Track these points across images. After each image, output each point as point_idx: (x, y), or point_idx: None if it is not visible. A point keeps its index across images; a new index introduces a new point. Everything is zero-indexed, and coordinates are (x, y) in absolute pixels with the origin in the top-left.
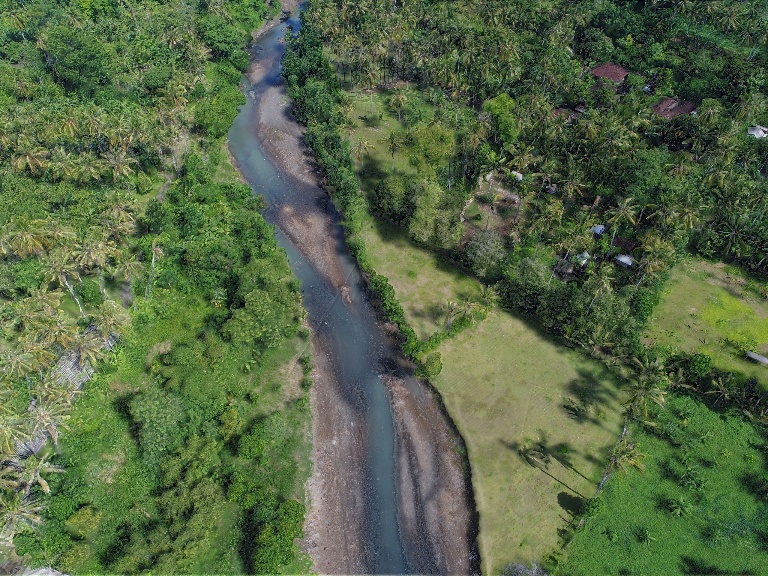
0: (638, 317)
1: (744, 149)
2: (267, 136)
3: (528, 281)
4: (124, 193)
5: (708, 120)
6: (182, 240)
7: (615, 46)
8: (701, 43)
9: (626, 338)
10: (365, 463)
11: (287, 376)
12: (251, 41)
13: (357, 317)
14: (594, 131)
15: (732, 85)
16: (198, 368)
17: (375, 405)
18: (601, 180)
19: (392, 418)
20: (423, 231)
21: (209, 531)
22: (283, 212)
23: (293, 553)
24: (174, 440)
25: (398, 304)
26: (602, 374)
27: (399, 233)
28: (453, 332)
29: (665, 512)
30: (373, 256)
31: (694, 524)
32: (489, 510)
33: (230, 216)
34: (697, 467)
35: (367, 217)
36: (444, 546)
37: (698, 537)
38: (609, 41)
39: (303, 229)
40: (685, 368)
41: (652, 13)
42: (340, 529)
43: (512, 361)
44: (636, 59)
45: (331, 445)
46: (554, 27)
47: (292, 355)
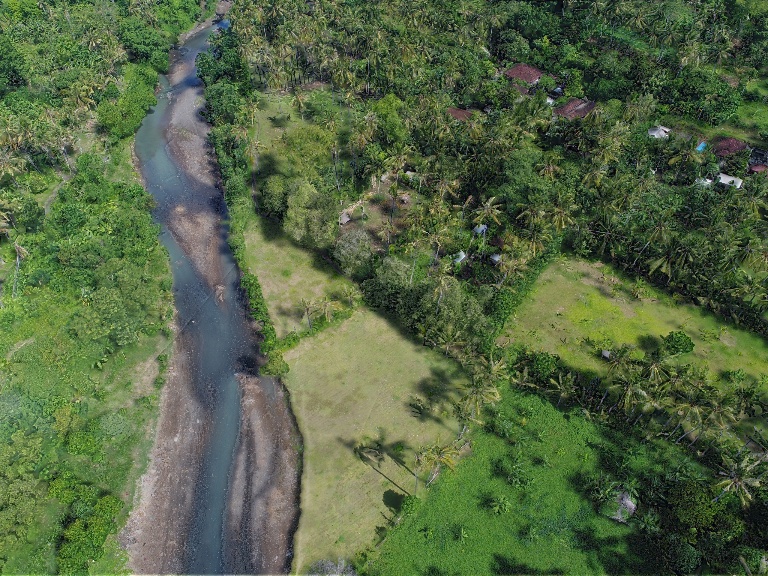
0: (496, 316)
1: (635, 149)
2: (174, 137)
3: (388, 280)
4: (17, 193)
5: (593, 120)
6: (61, 239)
7: (532, 47)
8: (615, 44)
9: (477, 337)
10: (203, 460)
11: (142, 374)
12: (178, 43)
13: (226, 316)
14: (478, 131)
15: (636, 86)
16: (43, 365)
17: (225, 403)
18: (486, 180)
19: (239, 416)
20: (295, 230)
21: (30, 527)
22: (174, 212)
23: (103, 549)
24: (1, 436)
25: (264, 303)
26: (455, 373)
27: (282, 233)
28: (314, 331)
29: (487, 510)
30: (251, 255)
31: (514, 522)
32: (312, 507)
33: (113, 215)
34: (529, 466)
35: (253, 217)
36: (264, 543)
37: (515, 535)
38: (525, 42)
39: (190, 228)
40: (531, 367)
41: (569, 14)
42: (163, 525)
43: (368, 360)
44: (550, 60)
45: (172, 442)
46: (462, 28)
47: (151, 353)
